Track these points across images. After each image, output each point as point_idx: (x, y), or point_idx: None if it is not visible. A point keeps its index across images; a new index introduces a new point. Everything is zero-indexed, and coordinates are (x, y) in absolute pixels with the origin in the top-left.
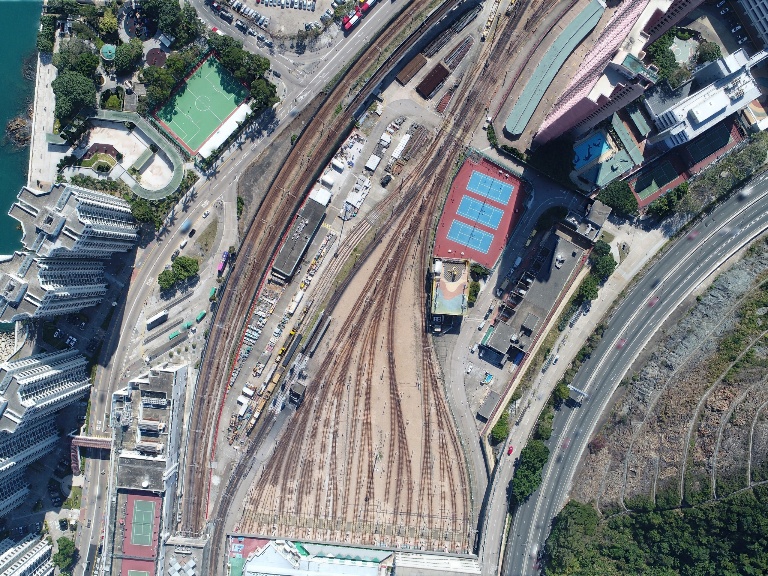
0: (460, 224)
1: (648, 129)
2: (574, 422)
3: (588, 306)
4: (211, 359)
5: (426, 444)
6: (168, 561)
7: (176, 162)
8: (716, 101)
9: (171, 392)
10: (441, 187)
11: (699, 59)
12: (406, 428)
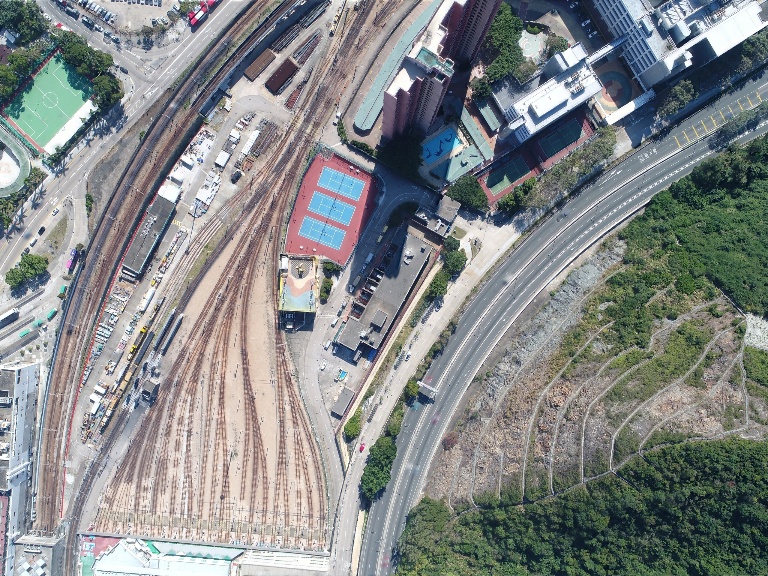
0: (312, 220)
1: (498, 124)
2: (427, 418)
3: (440, 302)
4: (62, 357)
5: (281, 441)
6: (18, 560)
7: (22, 159)
8: (555, 95)
9: (13, 391)
10: (292, 183)
11: (549, 53)
12: (261, 425)
